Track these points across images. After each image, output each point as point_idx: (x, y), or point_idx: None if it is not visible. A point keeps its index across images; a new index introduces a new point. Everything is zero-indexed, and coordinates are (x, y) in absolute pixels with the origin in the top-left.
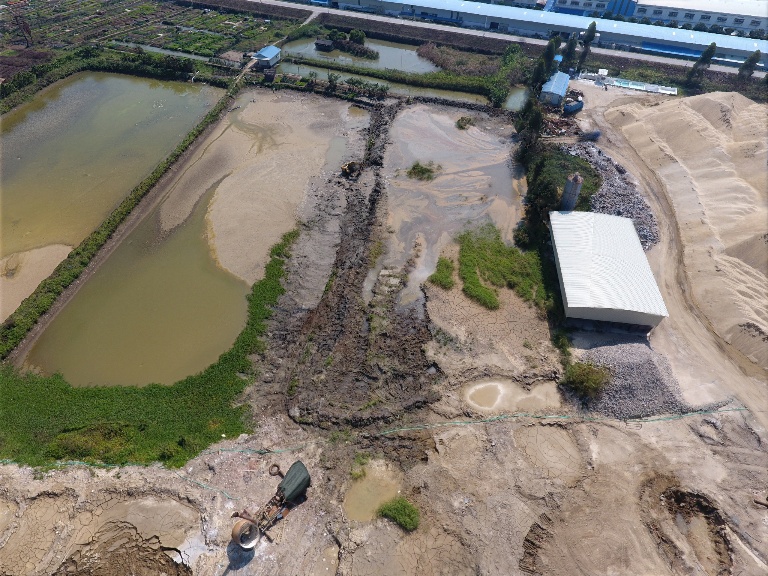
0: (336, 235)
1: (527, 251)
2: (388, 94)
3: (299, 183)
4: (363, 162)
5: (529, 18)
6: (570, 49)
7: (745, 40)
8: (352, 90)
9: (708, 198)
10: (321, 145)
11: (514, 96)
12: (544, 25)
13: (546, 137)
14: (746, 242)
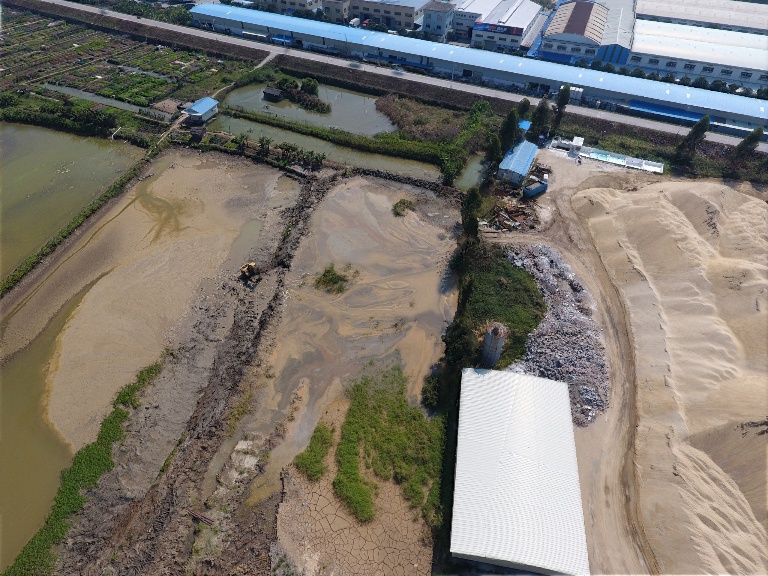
0: (205, 373)
1: (433, 416)
2: (325, 163)
3: (187, 288)
4: (272, 258)
5: (505, 67)
6: (541, 113)
7: (750, 102)
8: (286, 156)
9: (677, 344)
10: (230, 231)
11: (472, 167)
12: (521, 76)
13: (493, 234)
14: (717, 430)
